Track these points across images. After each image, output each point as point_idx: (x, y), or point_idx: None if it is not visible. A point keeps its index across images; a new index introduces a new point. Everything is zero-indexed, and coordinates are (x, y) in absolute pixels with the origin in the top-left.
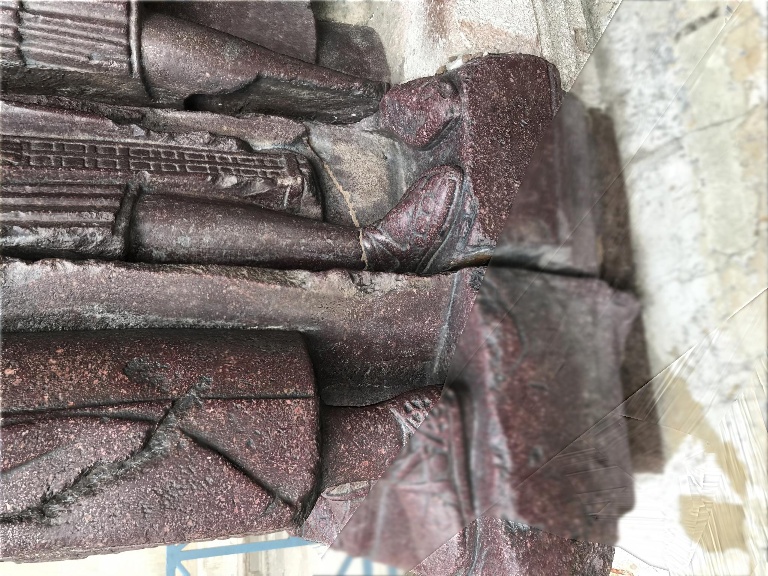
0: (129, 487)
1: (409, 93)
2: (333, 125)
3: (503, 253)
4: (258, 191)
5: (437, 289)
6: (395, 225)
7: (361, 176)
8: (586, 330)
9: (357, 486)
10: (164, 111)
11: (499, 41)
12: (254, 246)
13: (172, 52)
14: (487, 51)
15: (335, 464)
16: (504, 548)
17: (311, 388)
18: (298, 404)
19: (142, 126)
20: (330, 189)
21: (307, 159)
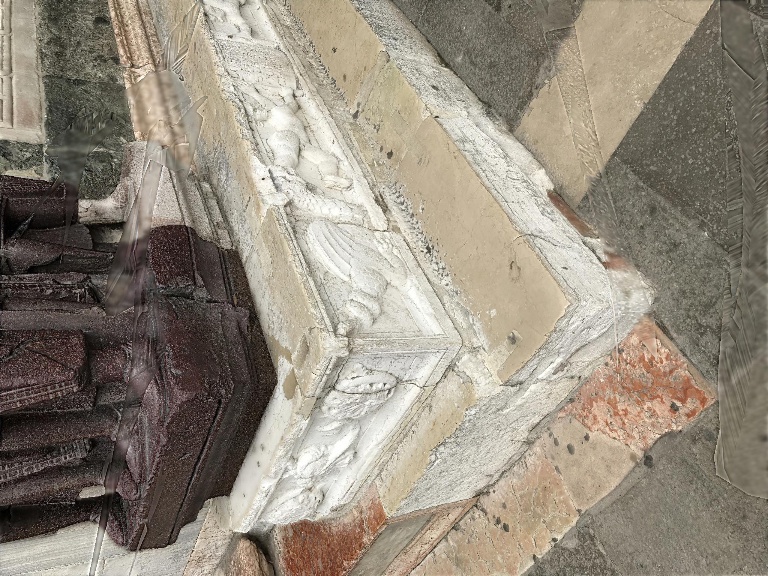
0: (4, 365)
1: None
2: (102, 274)
3: (120, 243)
4: (63, 296)
5: None
6: None
7: None
8: (57, 179)
9: None
10: (18, 275)
11: (164, 222)
12: None
13: (20, 249)
14: (159, 226)
15: (96, 366)
16: (171, 381)
17: (81, 336)
18: (75, 339)
19: None
20: (102, 298)
21: (88, 285)
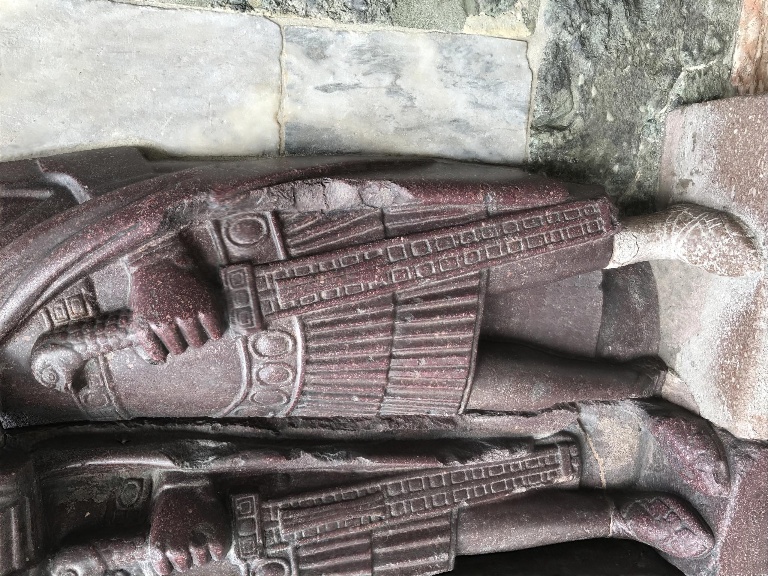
0: None
1: (684, 447)
2: (601, 403)
3: None
4: (538, 486)
5: None
6: (643, 534)
7: (616, 446)
8: None
9: None
10: (471, 417)
11: None
12: (533, 543)
13: (491, 402)
14: (767, 438)
15: None
16: None
17: None
18: None
19: (462, 458)
20: (588, 457)
21: None
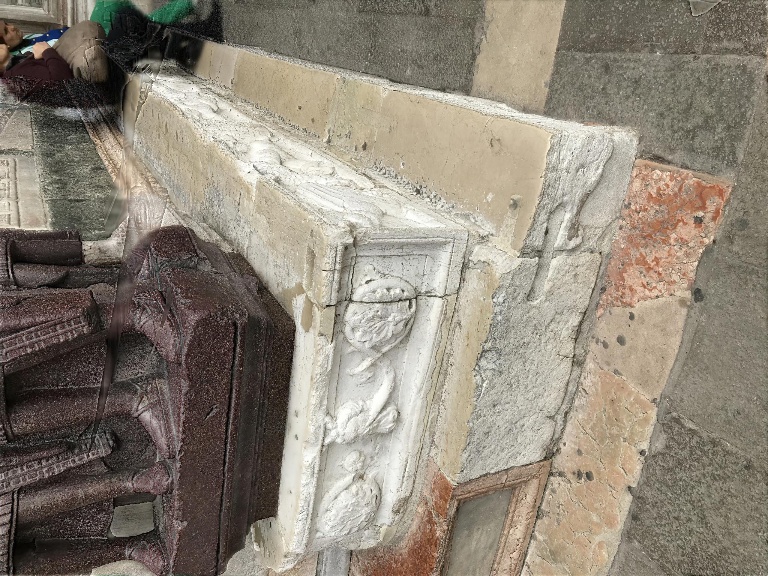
0: None
1: None
2: None
3: None
4: None
5: (151, 283)
6: None
7: None
8: None
9: (152, 400)
10: None
11: None
12: None
13: (27, 269)
14: None
15: (105, 314)
16: None
17: None
18: (82, 291)
19: None
20: None
21: None
